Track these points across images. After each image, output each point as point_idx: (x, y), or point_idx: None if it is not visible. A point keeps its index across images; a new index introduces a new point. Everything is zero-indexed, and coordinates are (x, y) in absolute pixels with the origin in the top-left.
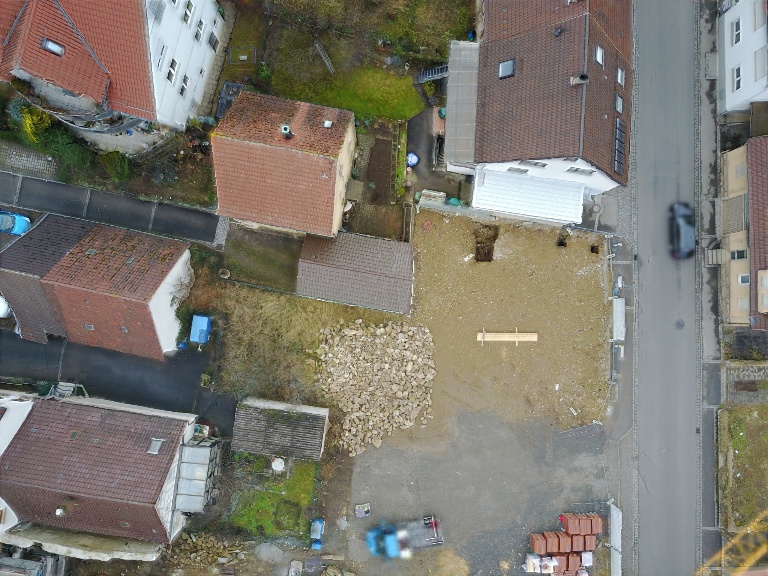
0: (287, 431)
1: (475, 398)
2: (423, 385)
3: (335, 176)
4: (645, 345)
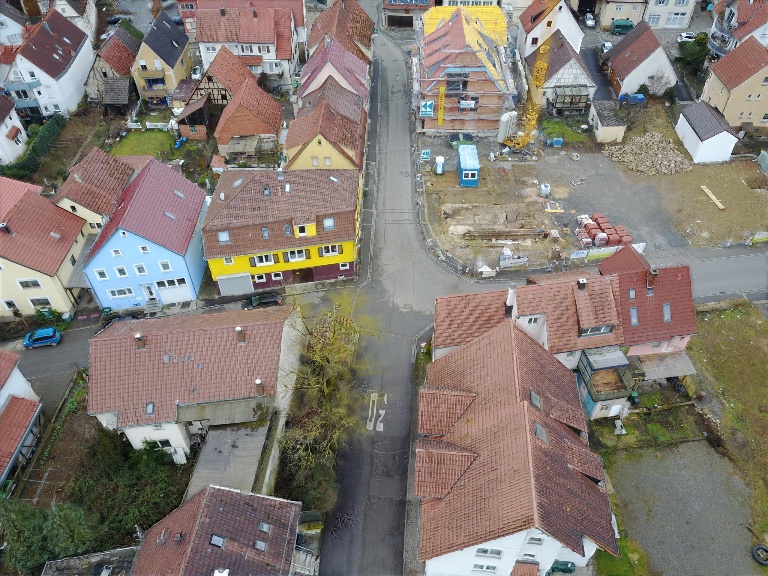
0: (611, 115)
1: (666, 191)
2: (659, 171)
3: (766, 66)
4: (759, 259)
